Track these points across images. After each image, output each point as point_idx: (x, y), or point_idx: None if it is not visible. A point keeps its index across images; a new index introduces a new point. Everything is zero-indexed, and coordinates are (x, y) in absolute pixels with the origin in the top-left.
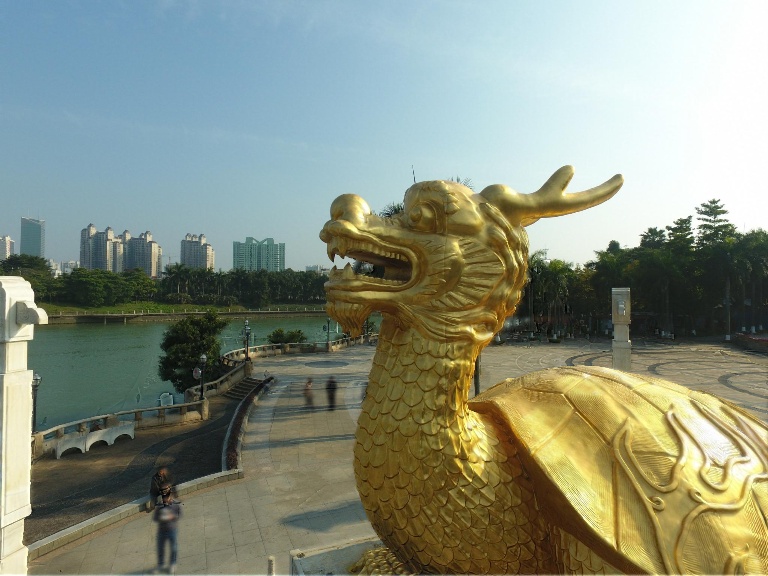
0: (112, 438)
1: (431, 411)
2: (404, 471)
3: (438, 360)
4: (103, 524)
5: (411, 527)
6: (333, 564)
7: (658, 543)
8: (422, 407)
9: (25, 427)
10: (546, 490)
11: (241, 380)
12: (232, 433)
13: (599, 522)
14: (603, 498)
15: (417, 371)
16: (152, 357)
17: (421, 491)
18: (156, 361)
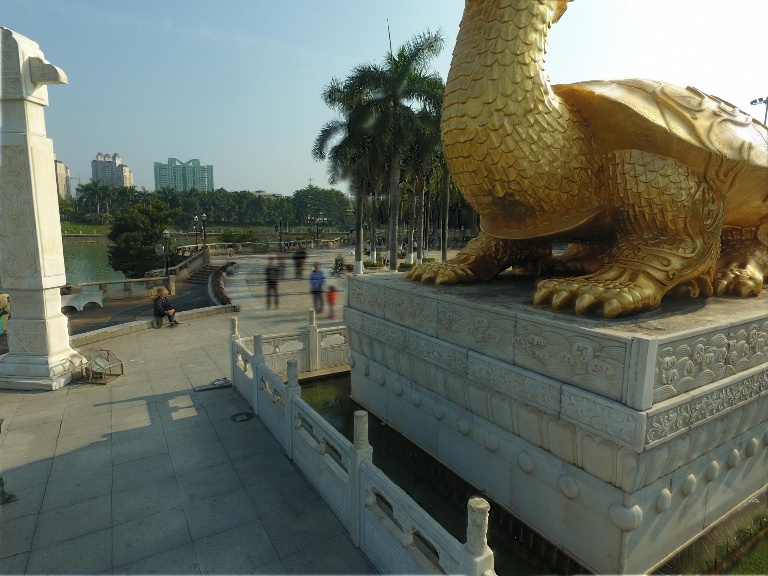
0: (81, 304)
1: (525, 45)
2: (502, 95)
3: (531, 1)
4: (116, 333)
5: (504, 146)
6: (386, 277)
7: (697, 132)
8: (518, 41)
9: (52, 196)
10: (608, 117)
11: (200, 267)
12: (215, 287)
13: (655, 120)
14: (654, 113)
15: (513, 11)
16: (100, 246)
17: (515, 111)
18: (104, 251)
